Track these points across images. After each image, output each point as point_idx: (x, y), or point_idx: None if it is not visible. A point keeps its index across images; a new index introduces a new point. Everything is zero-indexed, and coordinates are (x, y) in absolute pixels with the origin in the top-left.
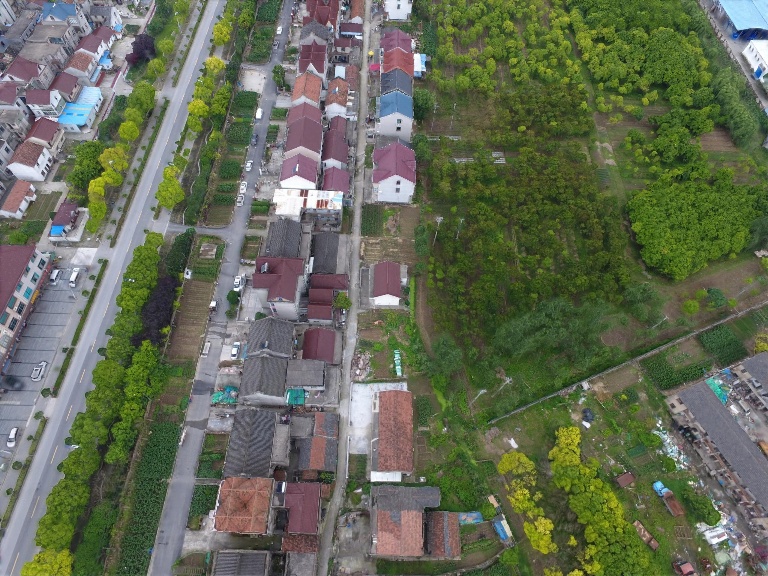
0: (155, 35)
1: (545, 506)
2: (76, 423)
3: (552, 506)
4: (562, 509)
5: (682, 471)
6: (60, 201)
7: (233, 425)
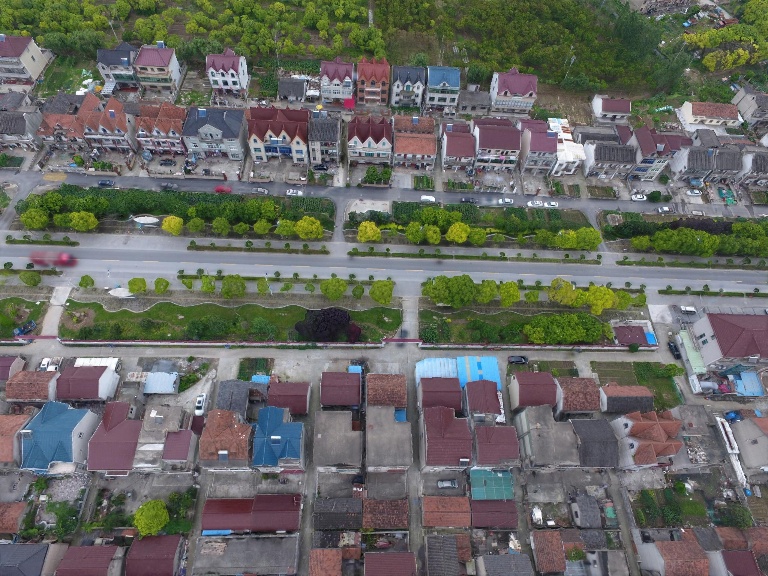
0: (276, 327)
1: (732, 50)
2: None
3: (731, 47)
4: (730, 45)
5: (672, 17)
6: (603, 360)
7: (762, 170)
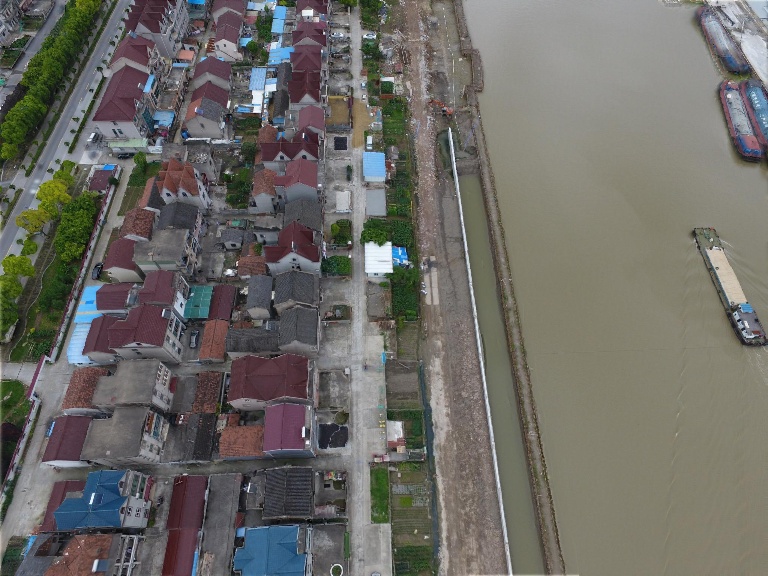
0: None
1: None
2: (64, 42)
3: None
4: None
5: None
6: (119, 206)
7: None
